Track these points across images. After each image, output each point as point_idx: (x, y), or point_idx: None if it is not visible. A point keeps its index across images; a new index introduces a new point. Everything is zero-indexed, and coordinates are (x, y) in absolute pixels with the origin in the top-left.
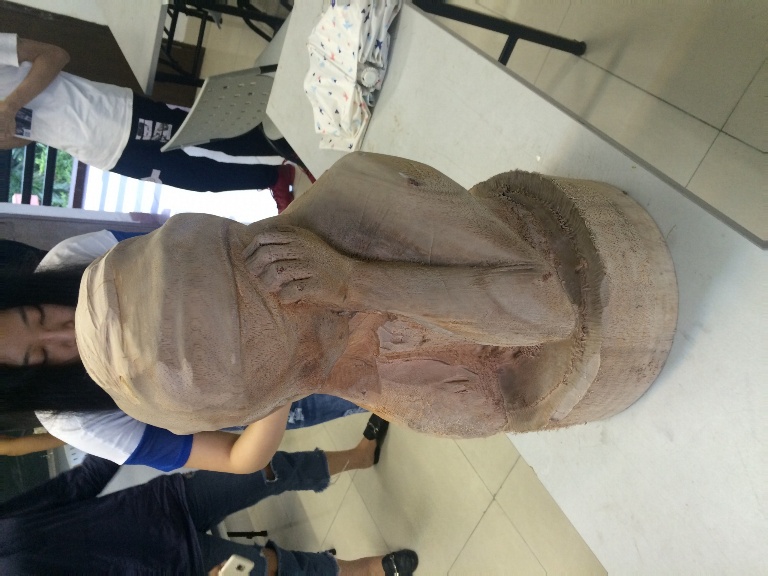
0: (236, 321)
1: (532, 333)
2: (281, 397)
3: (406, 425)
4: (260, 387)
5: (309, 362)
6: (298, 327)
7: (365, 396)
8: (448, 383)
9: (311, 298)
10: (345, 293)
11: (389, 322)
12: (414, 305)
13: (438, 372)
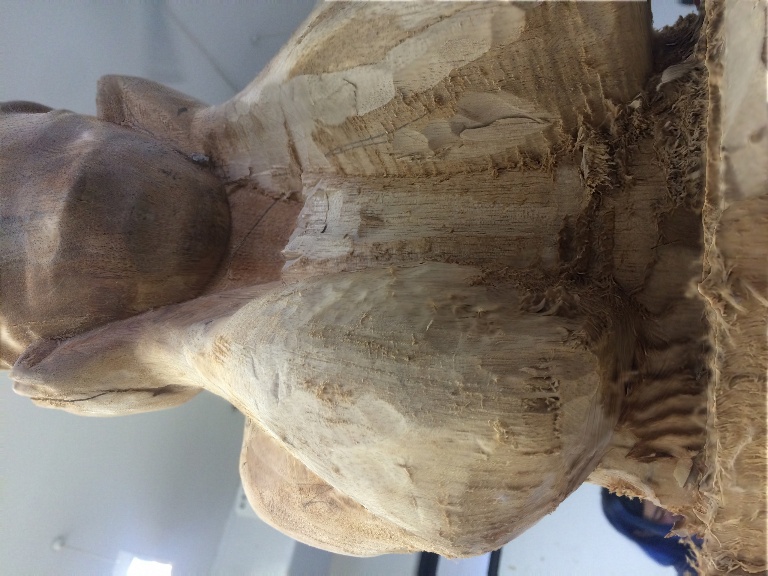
0: None
1: None
2: (3, 198)
3: (253, 380)
4: None
5: None
6: (92, 129)
7: (208, 328)
8: None
9: (128, 101)
10: (188, 108)
11: None
12: None
13: None
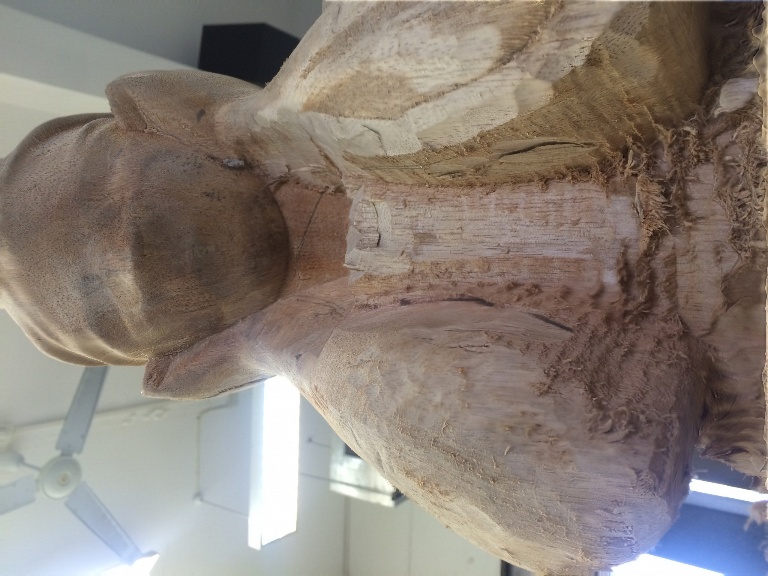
0: (35, 128)
1: (449, 1)
2: (75, 260)
3: None
4: (26, 215)
5: (116, 203)
6: (122, 154)
7: (299, 364)
8: (451, 331)
9: (143, 109)
10: (204, 108)
11: (352, 206)
12: (272, 83)
13: (451, 317)
